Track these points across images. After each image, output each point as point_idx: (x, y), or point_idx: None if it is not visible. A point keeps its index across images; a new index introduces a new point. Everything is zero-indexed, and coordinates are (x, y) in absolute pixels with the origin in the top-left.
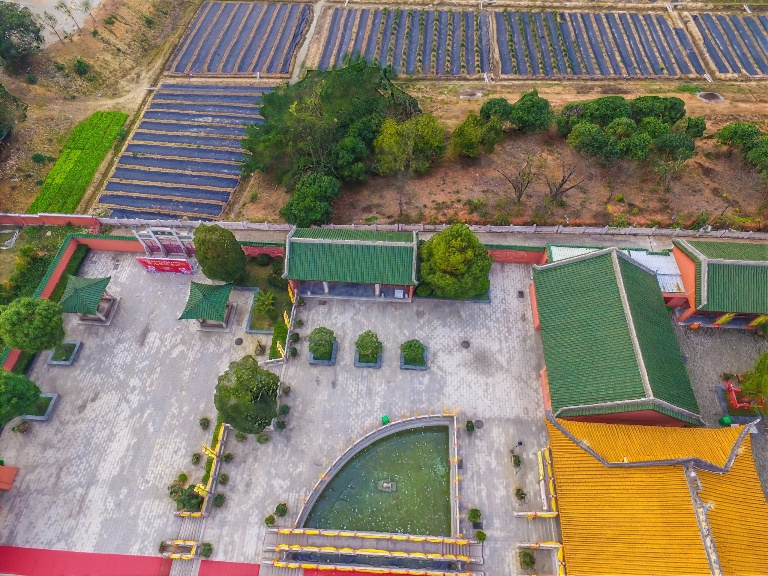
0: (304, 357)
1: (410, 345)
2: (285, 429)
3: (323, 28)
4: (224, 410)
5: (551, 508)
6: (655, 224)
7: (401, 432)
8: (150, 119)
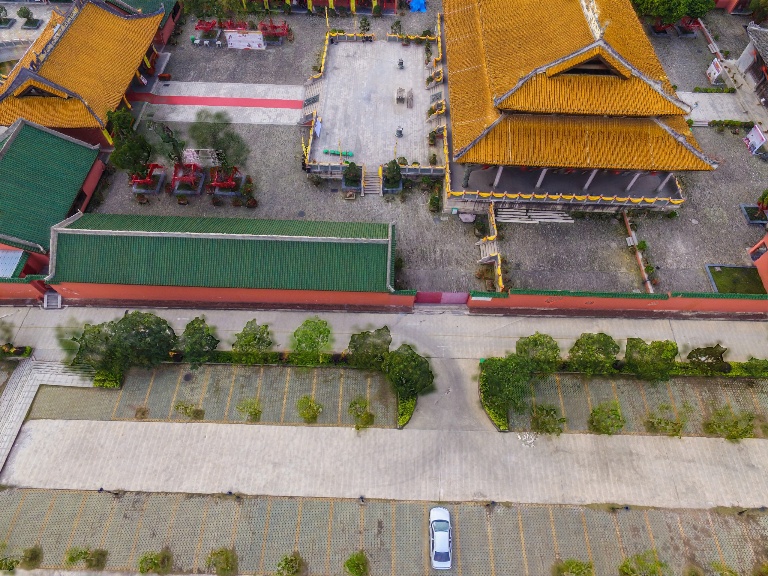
0: None
1: None
2: None
3: None
4: None
5: None
6: None
7: (15, 60)
8: None
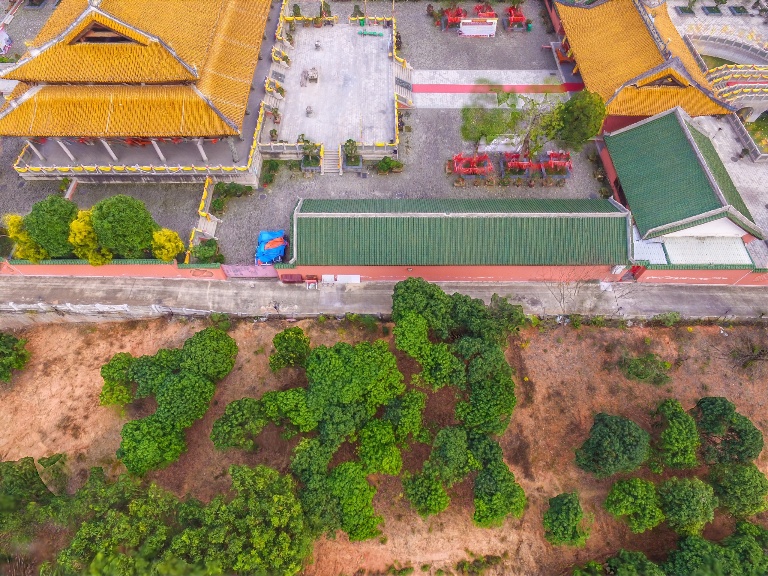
0: None
1: None
2: None
3: None
4: None
5: None
6: None
7: None
8: None
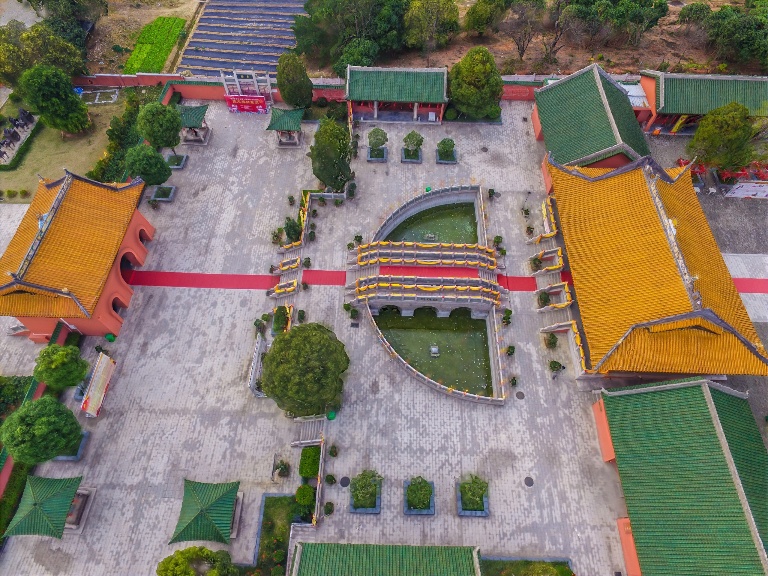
0: (363, 158)
1: (444, 142)
2: (354, 199)
3: None
4: (320, 157)
5: (552, 230)
6: (628, 72)
7: (439, 207)
8: (205, 23)
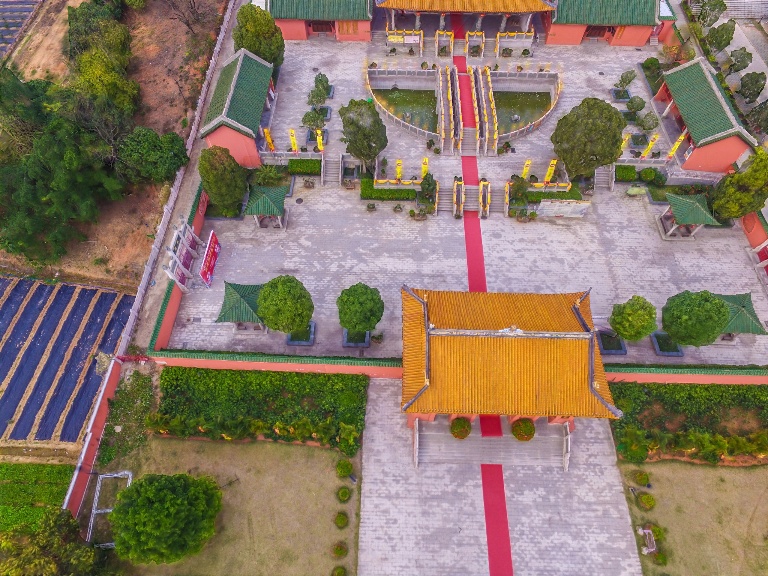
0: None
1: (319, 80)
2: None
3: None
4: None
5: (419, 34)
6: None
7: None
8: None
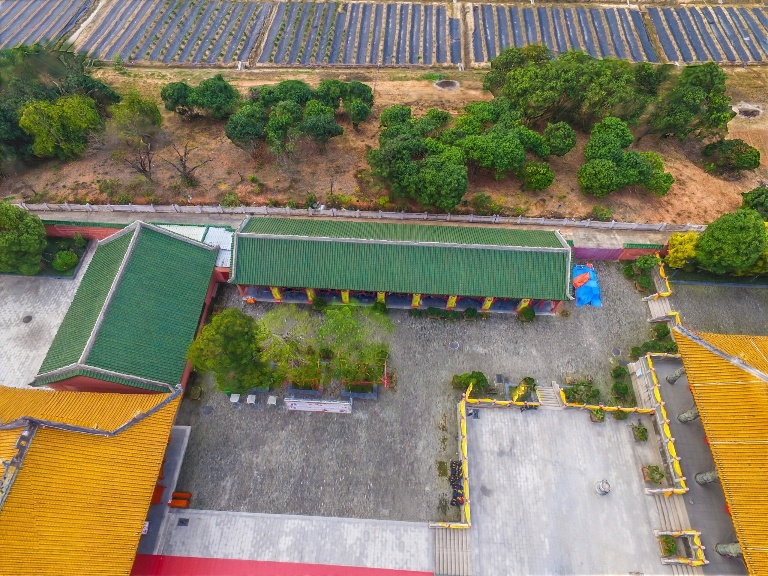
0: None
1: None
2: None
3: (100, 17)
4: None
5: None
6: (272, 203)
7: None
8: None
